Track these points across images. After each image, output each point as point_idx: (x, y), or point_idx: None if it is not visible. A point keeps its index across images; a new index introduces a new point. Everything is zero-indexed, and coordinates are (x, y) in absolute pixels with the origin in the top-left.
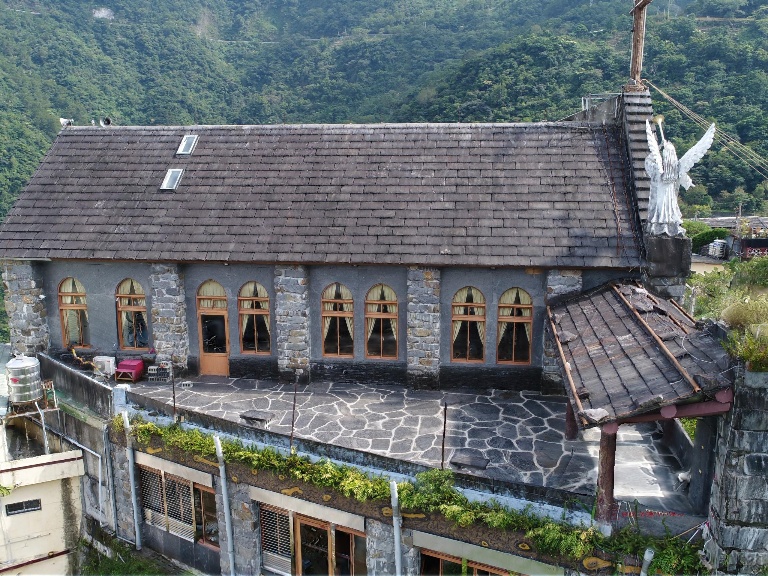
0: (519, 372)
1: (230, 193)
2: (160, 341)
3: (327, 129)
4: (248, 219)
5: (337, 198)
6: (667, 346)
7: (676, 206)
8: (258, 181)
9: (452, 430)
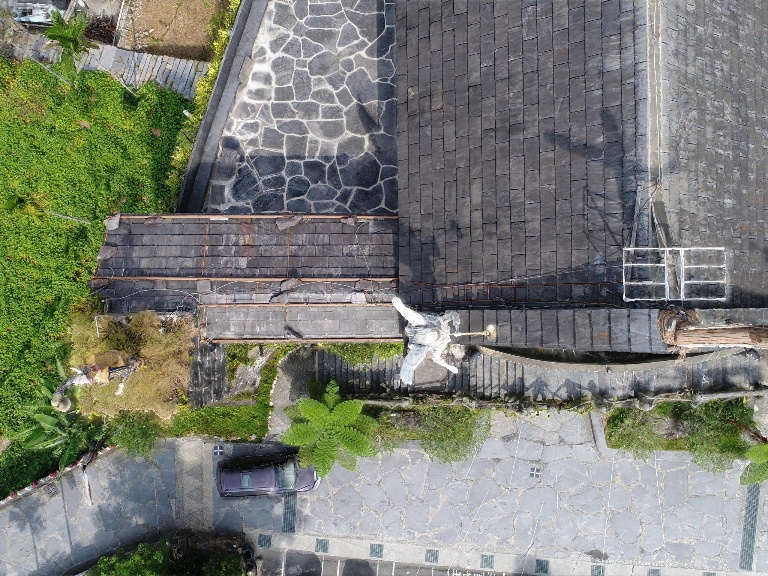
0: None
1: None
2: None
3: None
4: None
5: None
6: (187, 282)
7: None
8: None
9: (318, 147)
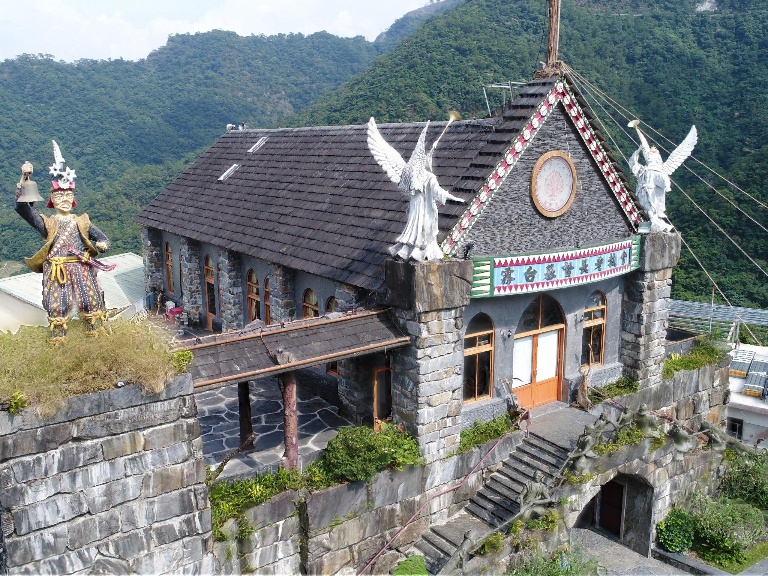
0: (333, 385)
1: (241, 185)
2: (185, 296)
3: (331, 130)
4: (229, 207)
5: (279, 194)
6: None
7: (432, 224)
8: (260, 176)
9: (204, 411)
